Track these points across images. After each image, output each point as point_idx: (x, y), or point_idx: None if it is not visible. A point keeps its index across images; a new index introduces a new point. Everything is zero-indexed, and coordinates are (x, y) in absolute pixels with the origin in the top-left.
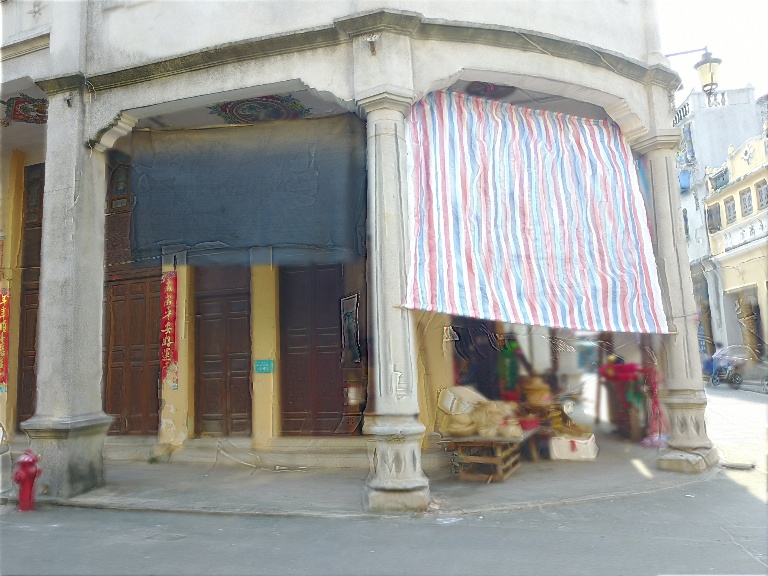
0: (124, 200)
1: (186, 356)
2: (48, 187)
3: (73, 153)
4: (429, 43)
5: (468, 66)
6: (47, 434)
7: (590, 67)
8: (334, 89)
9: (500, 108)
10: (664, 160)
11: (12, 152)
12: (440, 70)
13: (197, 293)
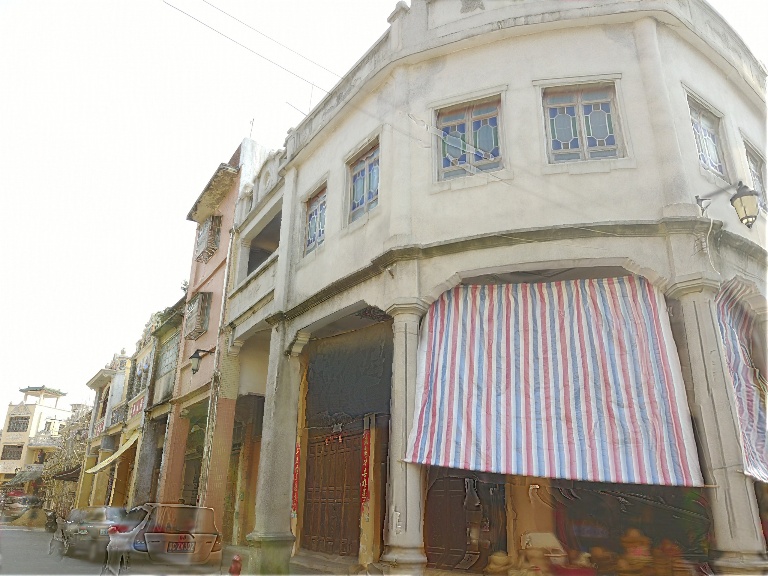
0: None
1: (373, 495)
2: None
3: (277, 360)
4: (433, 259)
5: (460, 270)
6: (254, 544)
7: (582, 240)
8: (378, 304)
9: (516, 288)
10: (692, 304)
11: None
12: (439, 278)
13: (382, 445)
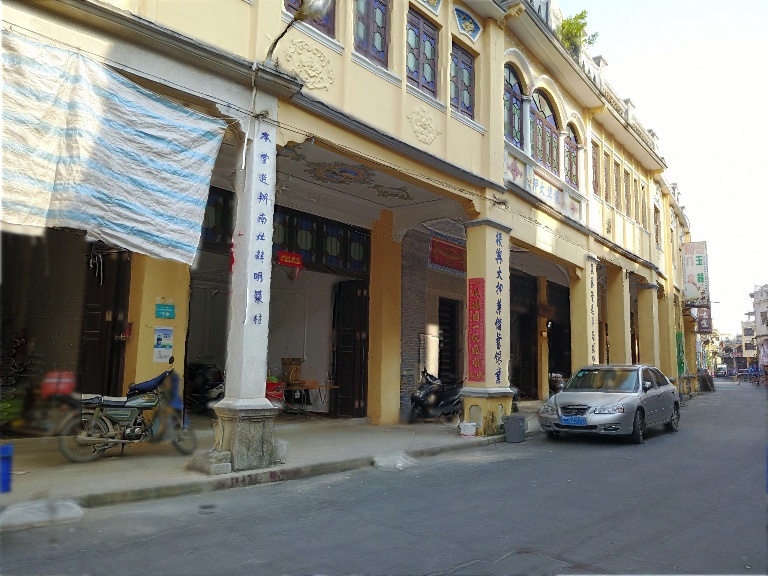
0: None
1: None
2: None
3: None
4: None
5: (764, 339)
6: None
7: None
8: None
9: None
10: None
11: None
12: None
13: None
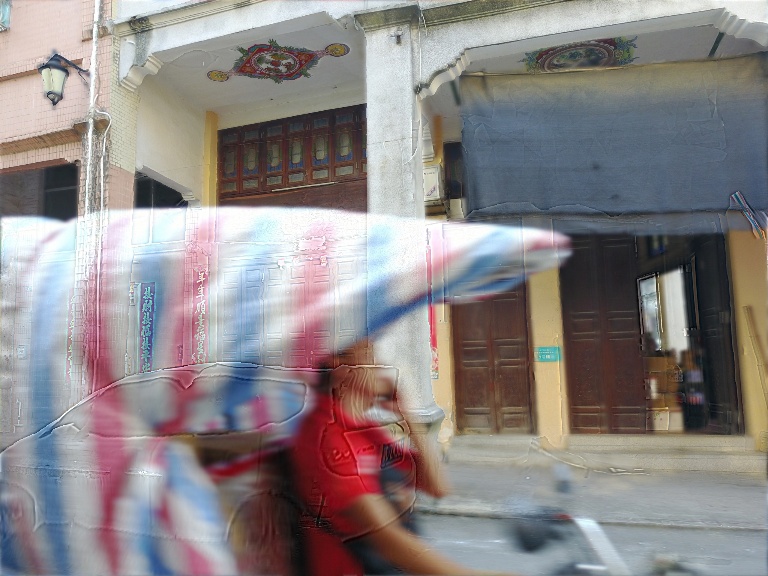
0: (350, 167)
1: (447, 342)
2: (374, 138)
3: (406, 98)
4: None
5: None
6: None
7: None
8: None
9: None
10: None
11: (206, 114)
12: None
13: (454, 271)
